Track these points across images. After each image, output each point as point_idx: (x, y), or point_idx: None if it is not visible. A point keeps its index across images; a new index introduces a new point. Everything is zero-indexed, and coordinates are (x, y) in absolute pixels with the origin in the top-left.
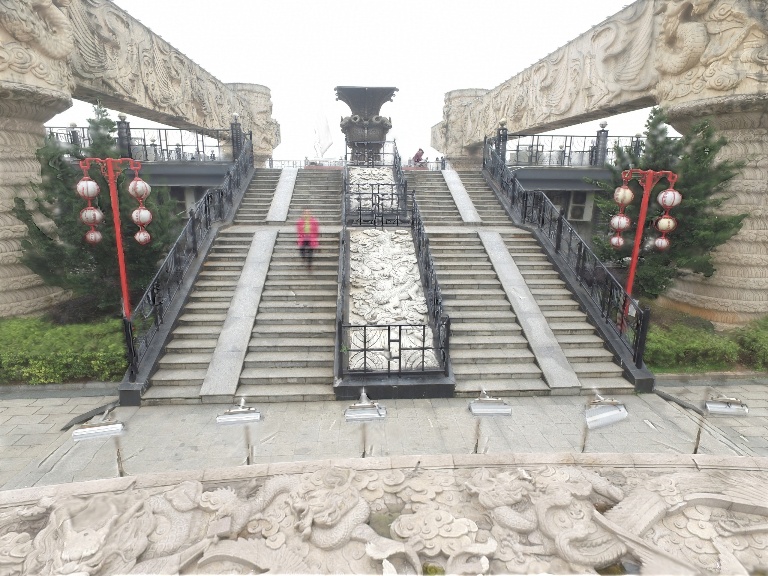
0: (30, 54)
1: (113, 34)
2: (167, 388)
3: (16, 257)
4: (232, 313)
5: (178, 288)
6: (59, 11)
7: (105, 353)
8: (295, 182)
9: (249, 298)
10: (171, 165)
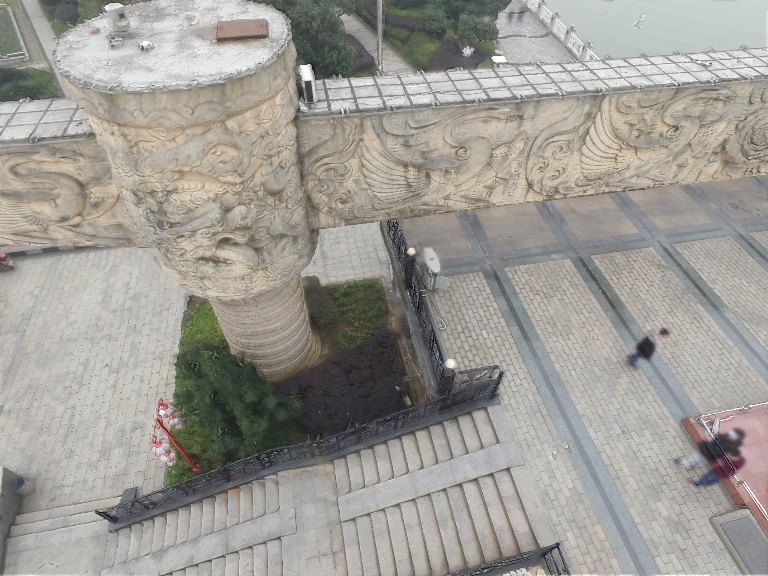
0: (204, 282)
1: (462, 147)
2: (117, 542)
3: (239, 350)
4: (165, 553)
5: (185, 495)
6: (228, 253)
7: (168, 473)
8: (457, 484)
9: (180, 559)
10: (415, 327)
